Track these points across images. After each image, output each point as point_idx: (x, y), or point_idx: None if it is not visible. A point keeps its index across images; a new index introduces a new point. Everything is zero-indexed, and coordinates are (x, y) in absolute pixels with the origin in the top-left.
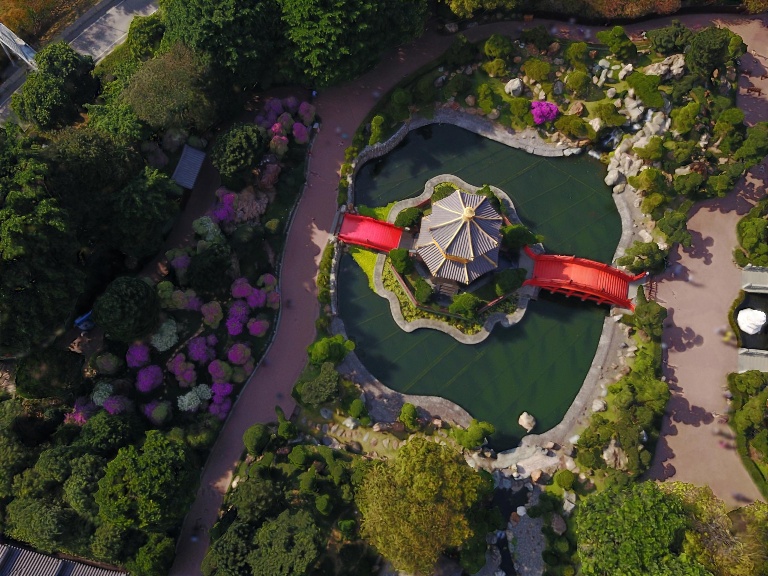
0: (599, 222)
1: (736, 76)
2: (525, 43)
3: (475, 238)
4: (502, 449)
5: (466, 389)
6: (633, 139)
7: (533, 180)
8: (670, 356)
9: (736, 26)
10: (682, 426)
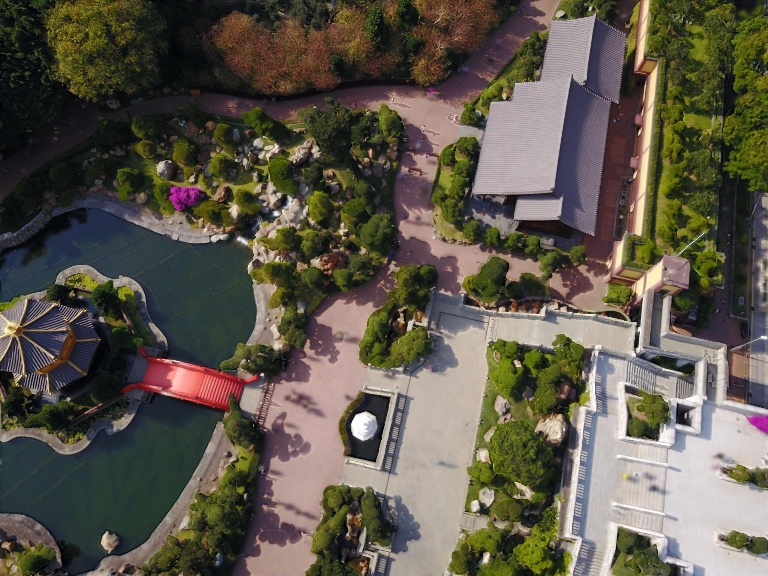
0: (236, 315)
1: (398, 155)
2: (186, 120)
3: (29, 353)
4: (76, 573)
5: (57, 504)
6: (269, 227)
7: (175, 269)
8: (271, 466)
9: (411, 99)
10: (267, 546)
